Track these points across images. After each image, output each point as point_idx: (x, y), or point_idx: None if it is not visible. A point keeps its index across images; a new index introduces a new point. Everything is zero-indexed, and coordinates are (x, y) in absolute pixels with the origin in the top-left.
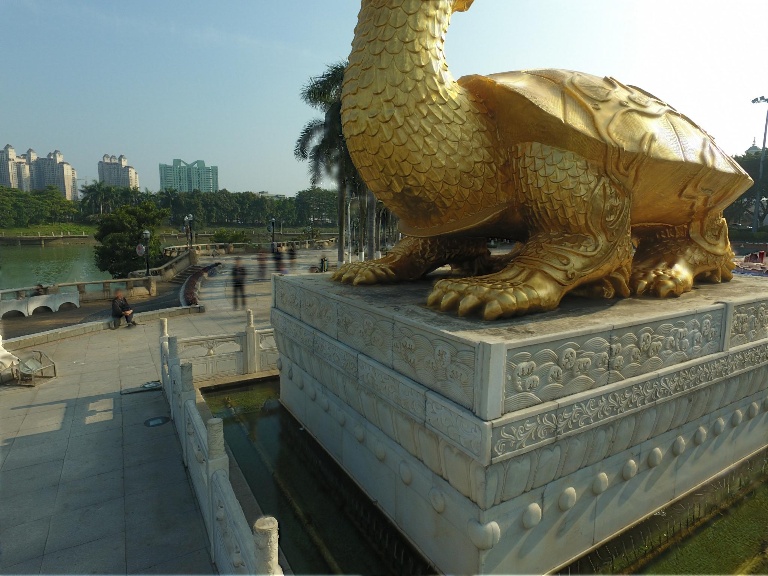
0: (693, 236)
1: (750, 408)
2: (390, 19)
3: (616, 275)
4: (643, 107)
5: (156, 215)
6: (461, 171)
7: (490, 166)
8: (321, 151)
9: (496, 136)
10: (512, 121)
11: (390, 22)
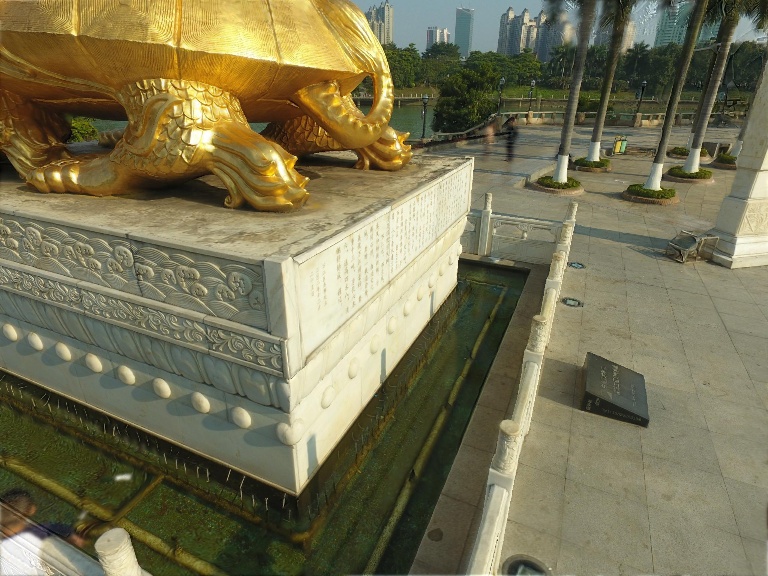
0: None
1: None
2: None
3: None
4: None
5: (487, 79)
6: None
7: None
8: None
9: None
10: None
11: None
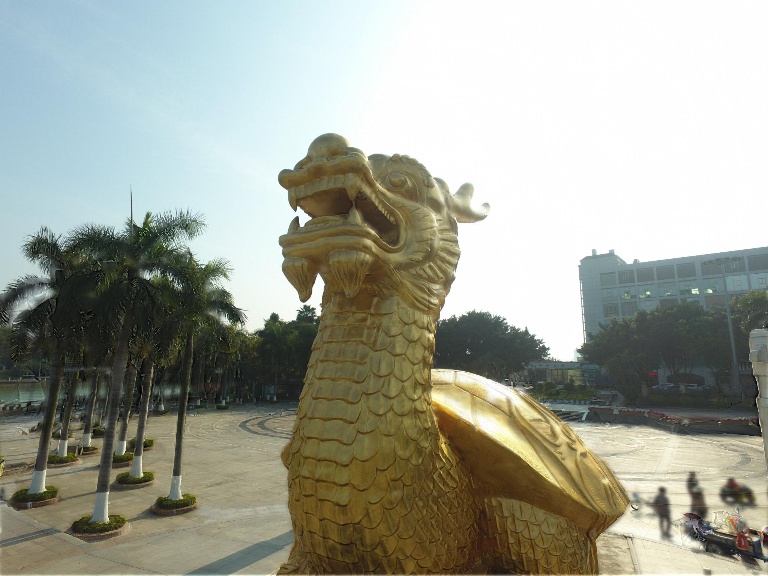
0: None
1: None
2: (395, 369)
3: None
4: (575, 442)
5: None
6: (458, 548)
7: (473, 526)
8: (34, 318)
9: (471, 483)
10: (498, 475)
11: (395, 373)
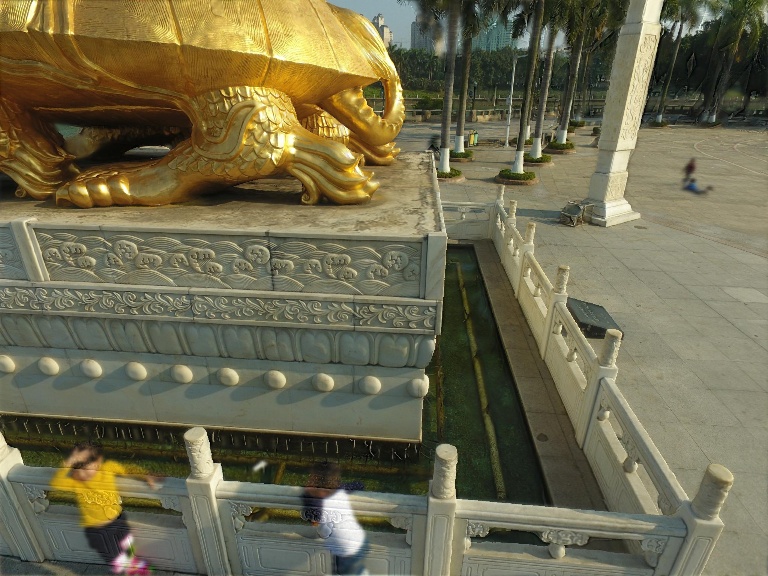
0: (198, 127)
1: (171, 369)
2: None
3: (4, 171)
4: None
5: None
6: None
7: None
8: None
9: None
10: None
11: None
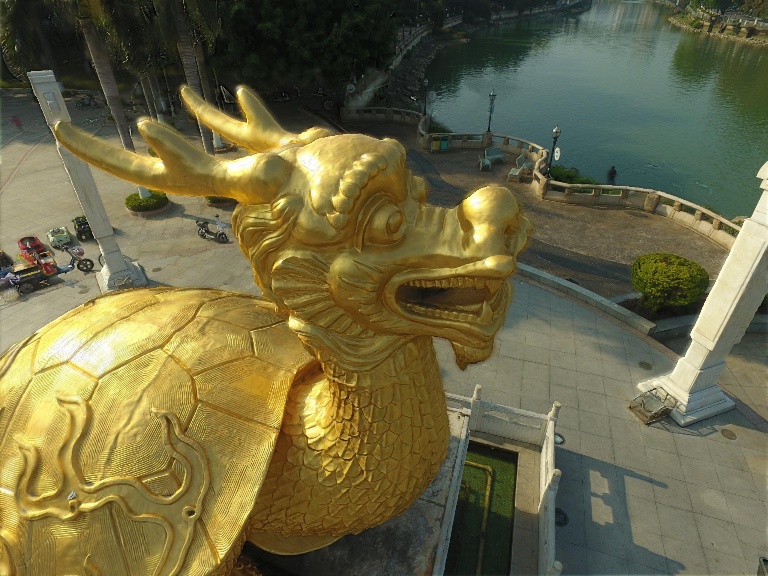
0: None
1: None
2: None
3: None
4: None
5: None
6: None
7: None
8: None
9: None
10: None
11: None
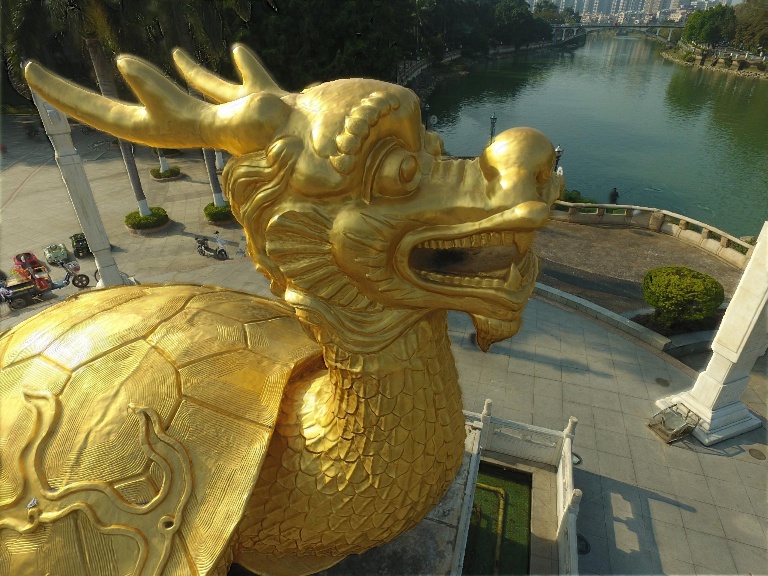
0: None
1: None
2: None
3: None
4: None
5: None
6: None
7: None
8: None
9: None
10: None
11: None
